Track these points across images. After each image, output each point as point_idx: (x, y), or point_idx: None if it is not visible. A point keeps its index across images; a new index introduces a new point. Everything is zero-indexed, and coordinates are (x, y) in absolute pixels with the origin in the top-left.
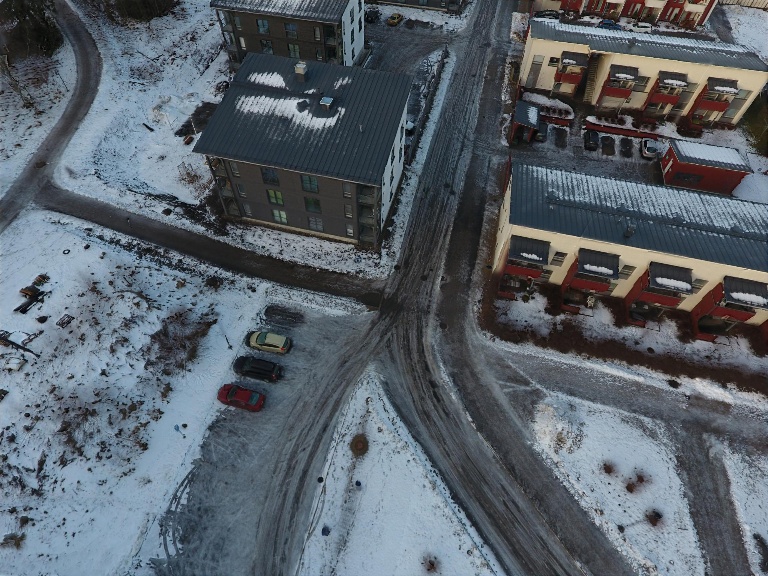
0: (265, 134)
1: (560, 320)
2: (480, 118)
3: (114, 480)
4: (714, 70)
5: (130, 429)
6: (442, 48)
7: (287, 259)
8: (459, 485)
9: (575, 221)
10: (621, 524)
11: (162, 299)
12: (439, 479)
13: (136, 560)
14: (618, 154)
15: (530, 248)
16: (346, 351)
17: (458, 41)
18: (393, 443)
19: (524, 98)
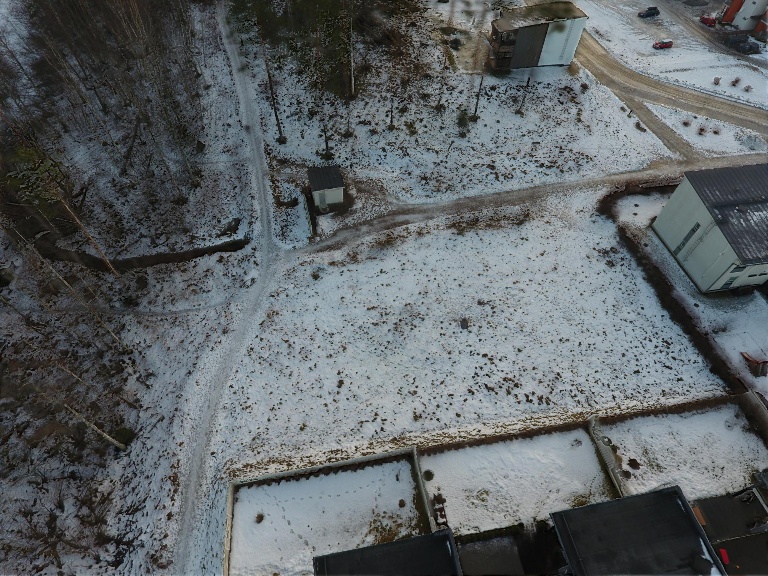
0: None
1: None
2: None
3: None
4: None
5: None
6: None
7: None
8: (763, 111)
9: None
10: None
11: None
12: None
13: None
14: None
15: None
16: None
17: None
18: None
19: None
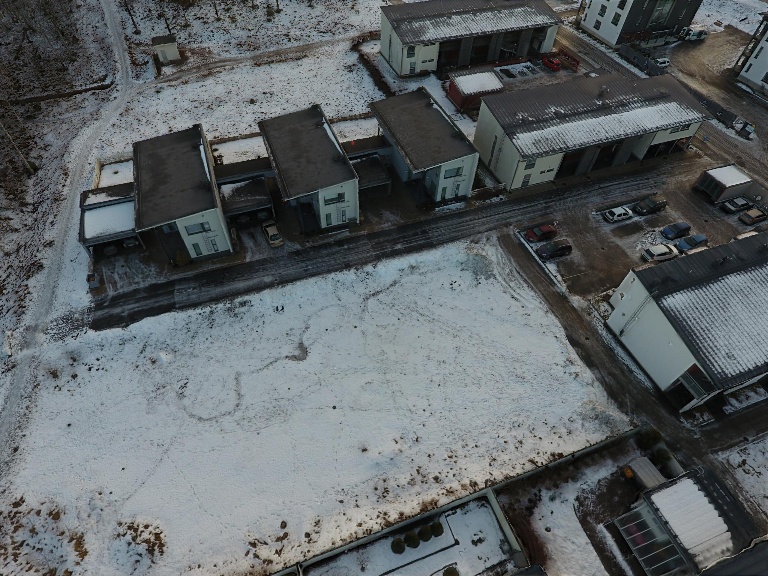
0: None
1: None
2: None
3: None
4: None
5: None
6: (759, 141)
7: None
8: None
9: None
10: None
11: None
12: None
13: None
14: None
15: None
16: None
17: (766, 156)
18: None
19: None
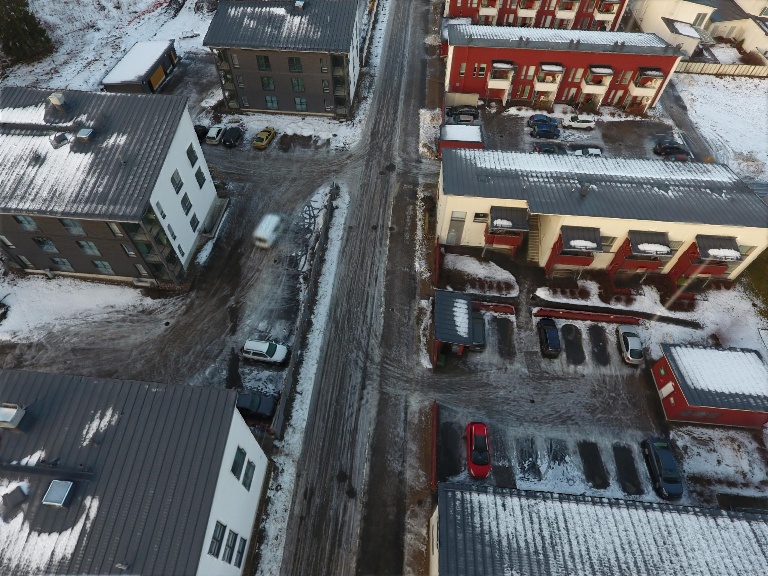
0: None
1: None
2: (387, 313)
3: None
4: (704, 227)
5: None
6: (329, 181)
7: None
8: None
9: None
10: None
11: None
12: None
13: None
14: (590, 360)
15: None
16: None
17: (351, 166)
18: None
19: (446, 266)
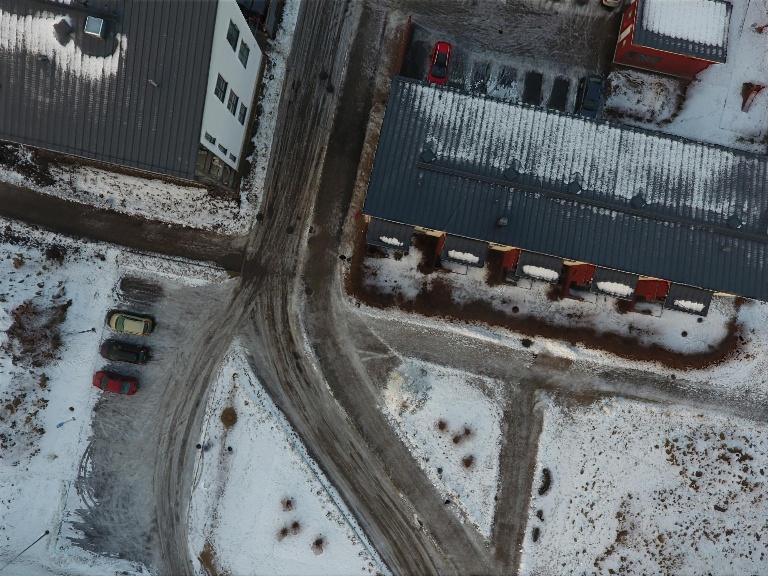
0: (24, 91)
1: (431, 279)
2: None
3: (25, 461)
4: None
5: (22, 420)
6: None
7: (132, 213)
8: (315, 444)
9: (444, 202)
10: (441, 467)
11: (3, 286)
12: (298, 440)
13: (65, 512)
14: None
15: (391, 230)
16: (210, 326)
17: None
18: (258, 414)
19: None
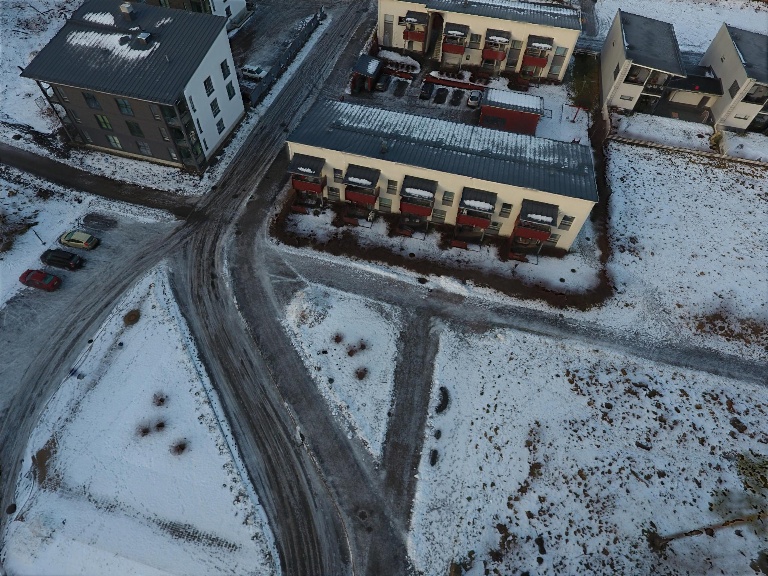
0: (86, 62)
1: (342, 230)
2: (334, 71)
3: None
4: (532, 28)
5: None
6: None
7: (117, 178)
8: (208, 348)
9: (345, 141)
10: (333, 378)
11: None
12: (192, 343)
13: None
14: (447, 103)
15: (307, 164)
16: (146, 249)
17: (339, 6)
18: (161, 317)
19: (379, 55)
